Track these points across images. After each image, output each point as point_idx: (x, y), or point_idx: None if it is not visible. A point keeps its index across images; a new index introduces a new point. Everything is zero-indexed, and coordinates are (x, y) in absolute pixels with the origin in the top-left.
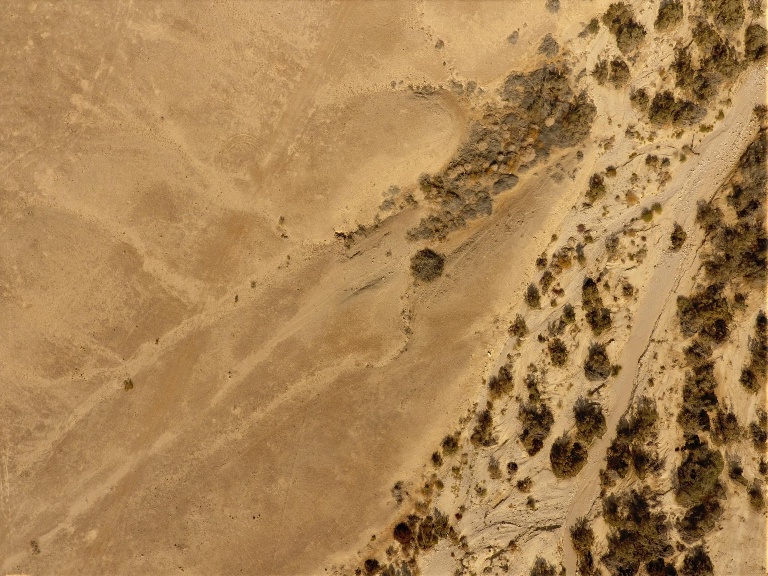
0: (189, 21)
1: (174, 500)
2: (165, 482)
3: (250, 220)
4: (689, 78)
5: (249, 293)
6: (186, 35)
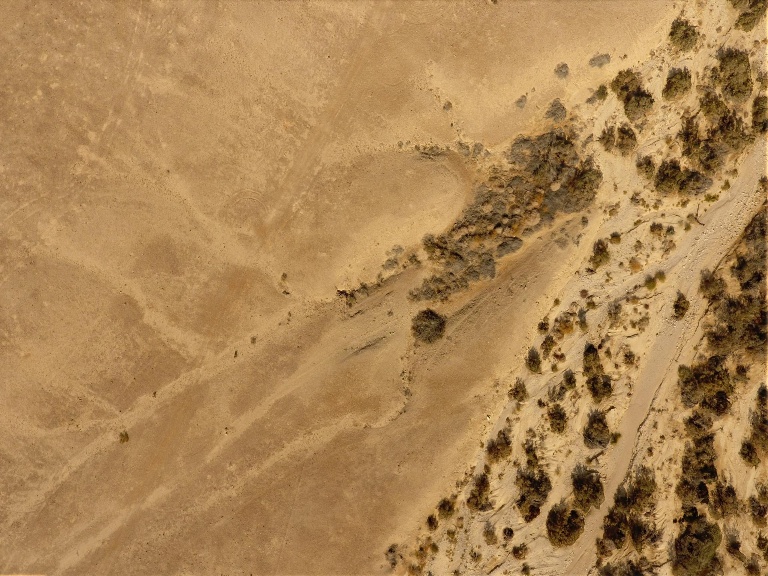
0: (198, 76)
1: (166, 556)
2: (157, 537)
3: (252, 275)
4: (696, 147)
5: (249, 349)
6: (195, 90)
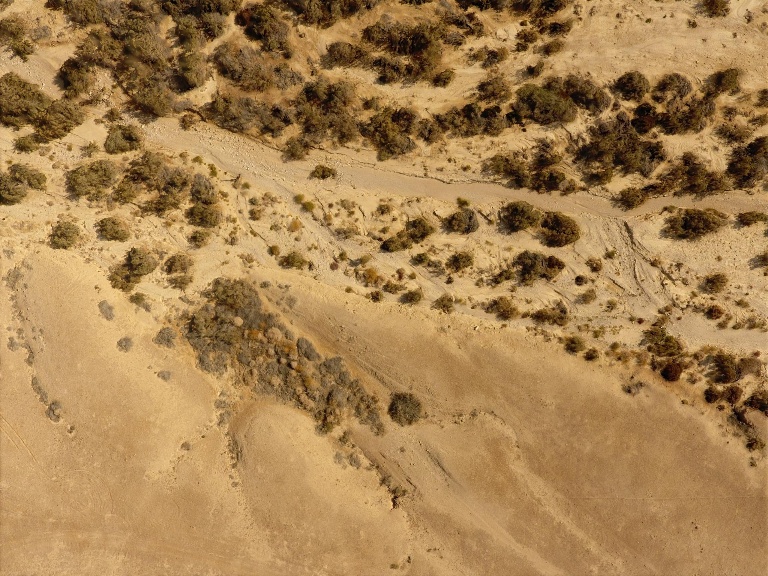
0: None
1: None
2: None
3: None
4: (168, 199)
5: None
6: None
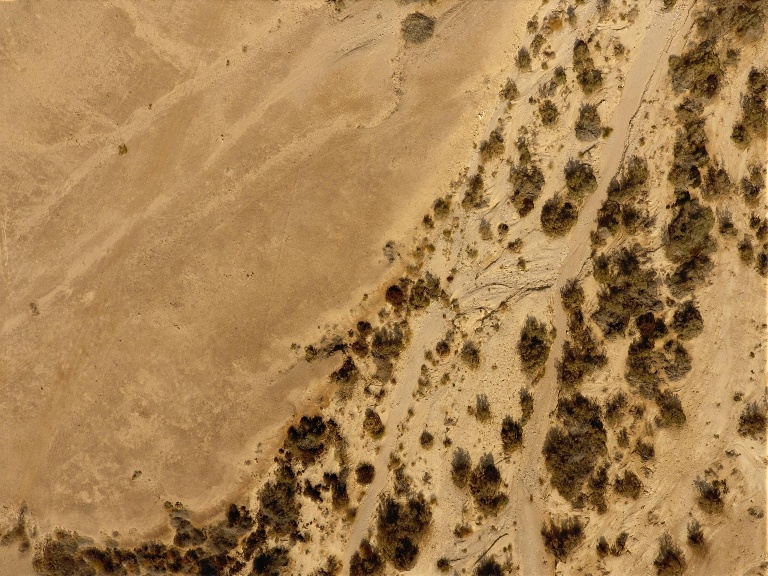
0: None
1: (169, 261)
2: (160, 244)
3: None
4: None
5: (240, 57)
6: None
